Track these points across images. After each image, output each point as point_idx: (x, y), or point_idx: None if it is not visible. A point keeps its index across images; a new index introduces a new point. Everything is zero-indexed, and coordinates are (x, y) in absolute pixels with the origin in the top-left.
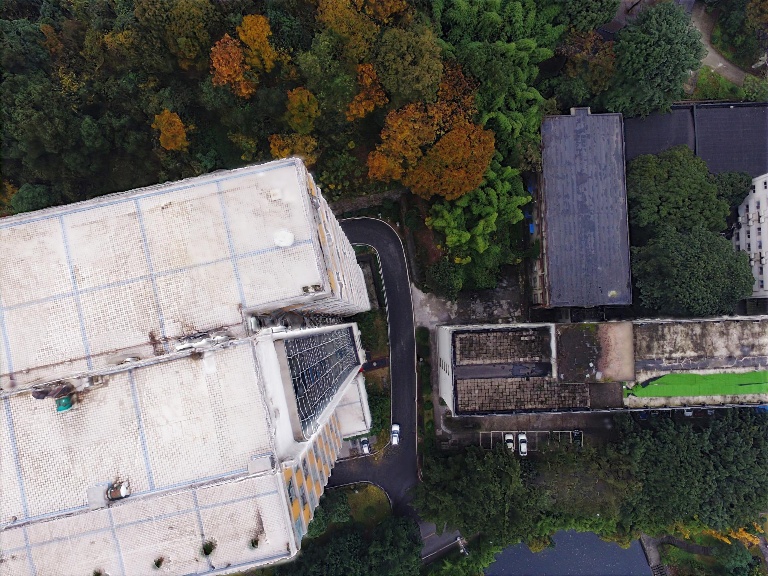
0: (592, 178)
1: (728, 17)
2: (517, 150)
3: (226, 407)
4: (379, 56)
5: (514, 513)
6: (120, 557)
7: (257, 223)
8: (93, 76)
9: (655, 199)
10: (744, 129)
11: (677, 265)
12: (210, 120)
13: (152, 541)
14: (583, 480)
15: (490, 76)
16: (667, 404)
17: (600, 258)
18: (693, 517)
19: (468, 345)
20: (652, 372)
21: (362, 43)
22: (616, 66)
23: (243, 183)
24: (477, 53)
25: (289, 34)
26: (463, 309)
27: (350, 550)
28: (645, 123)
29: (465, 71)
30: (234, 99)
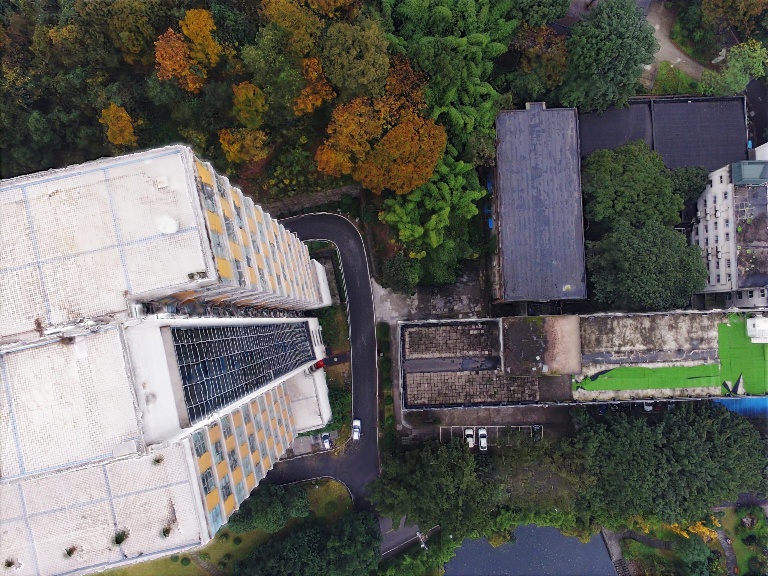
0: (547, 173)
1: (686, 12)
2: (470, 145)
3: (97, 391)
4: (325, 50)
5: (468, 507)
6: (33, 546)
7: (143, 210)
8: (43, 71)
9: (610, 194)
10: (702, 124)
11: (629, 259)
12: (163, 115)
13: (65, 530)
14: (537, 474)
15: (439, 70)
16: (616, 397)
17: (555, 252)
18: (652, 511)
19: (417, 339)
20: (601, 365)
21: (305, 37)
22: (569, 61)
23: (130, 171)
24: (424, 47)
25: (234, 28)
26: (424, 304)
27: (309, 545)
28: (603, 118)
29: (414, 65)
30: (181, 94)
